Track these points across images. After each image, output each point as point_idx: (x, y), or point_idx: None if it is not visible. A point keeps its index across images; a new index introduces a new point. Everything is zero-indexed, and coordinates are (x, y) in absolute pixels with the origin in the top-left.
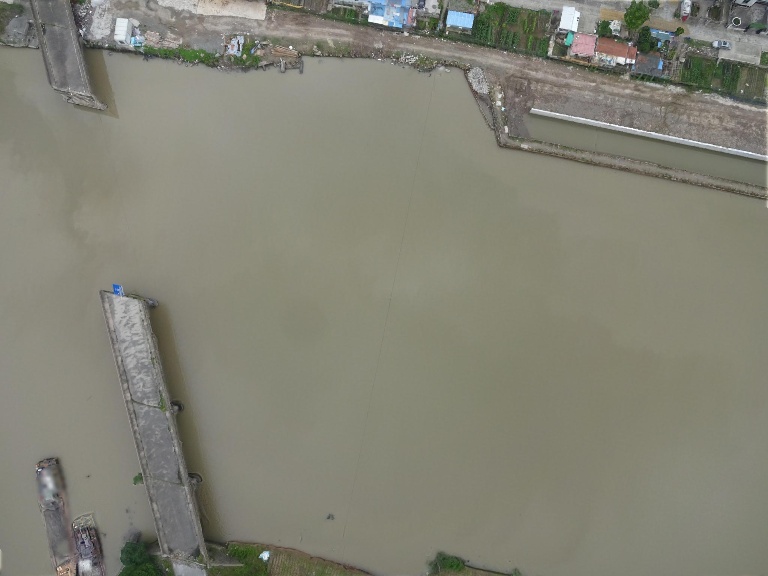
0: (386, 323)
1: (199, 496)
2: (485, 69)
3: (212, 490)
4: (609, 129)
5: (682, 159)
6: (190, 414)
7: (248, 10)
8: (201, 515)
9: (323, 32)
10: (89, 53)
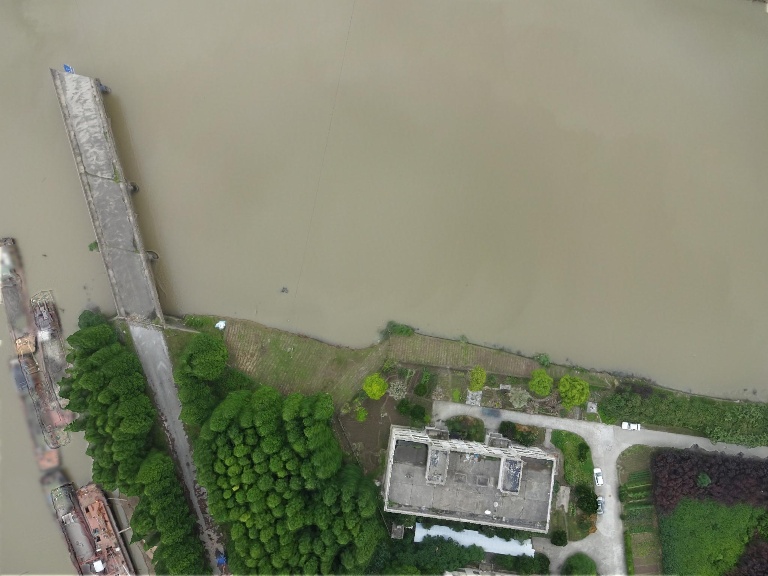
0: None
1: (156, 274)
2: None
3: (169, 274)
4: None
5: None
6: (146, 200)
7: None
8: (157, 285)
9: None
10: None
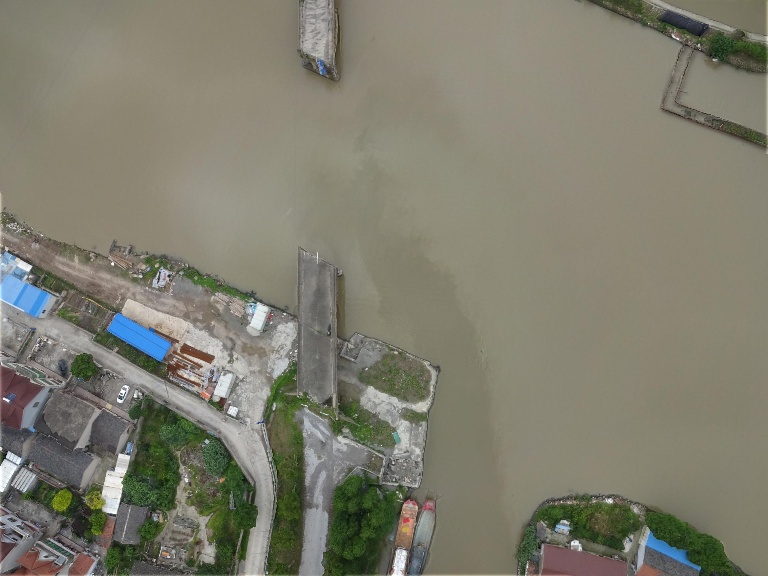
0: None
1: None
2: None
3: None
4: None
5: None
6: None
7: (140, 313)
8: None
9: (79, 271)
10: None
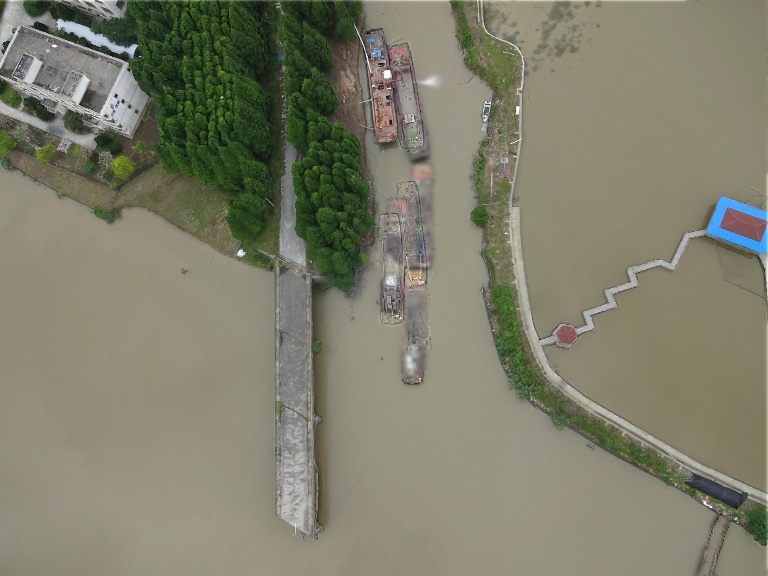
0: (75, 427)
1: None
2: None
3: None
4: None
5: None
6: None
7: None
8: None
9: None
10: None
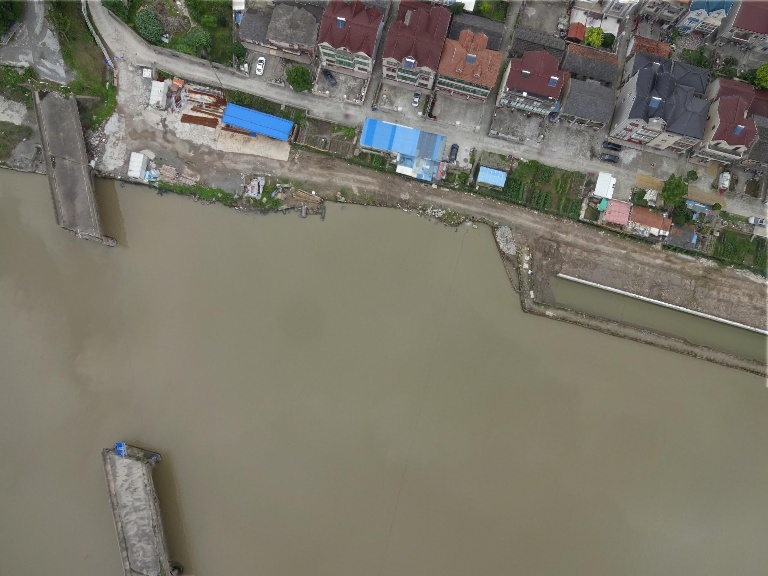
0: None
1: None
2: (514, 229)
3: None
4: (636, 298)
5: (708, 334)
6: (189, 572)
7: (271, 149)
8: None
9: (348, 178)
10: (100, 184)
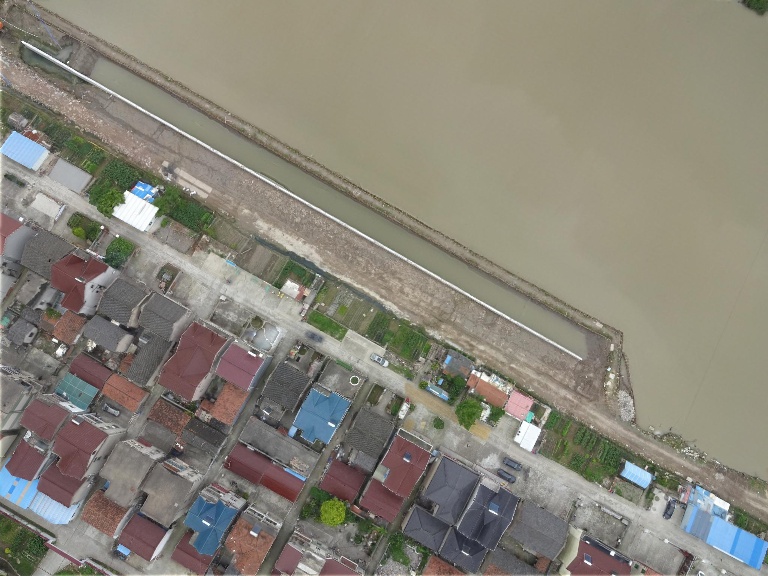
0: None
1: None
2: (617, 416)
3: None
4: None
5: (447, 267)
6: None
7: None
8: None
9: None
10: None
